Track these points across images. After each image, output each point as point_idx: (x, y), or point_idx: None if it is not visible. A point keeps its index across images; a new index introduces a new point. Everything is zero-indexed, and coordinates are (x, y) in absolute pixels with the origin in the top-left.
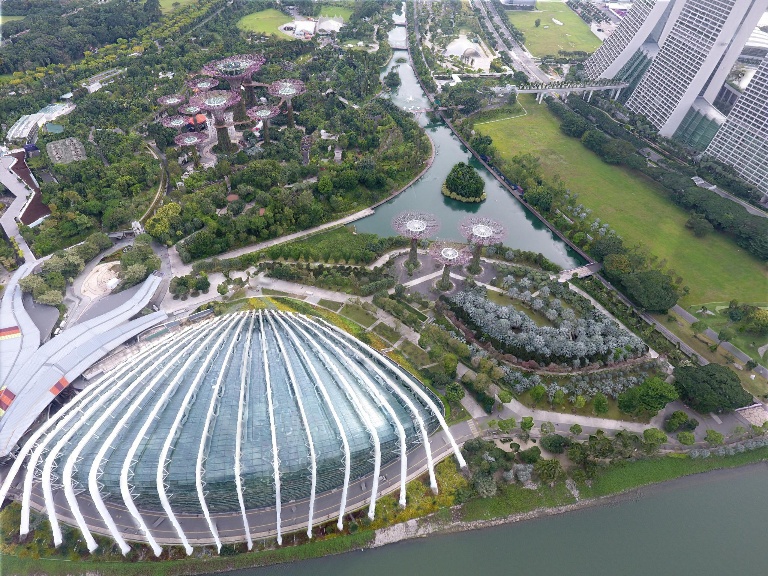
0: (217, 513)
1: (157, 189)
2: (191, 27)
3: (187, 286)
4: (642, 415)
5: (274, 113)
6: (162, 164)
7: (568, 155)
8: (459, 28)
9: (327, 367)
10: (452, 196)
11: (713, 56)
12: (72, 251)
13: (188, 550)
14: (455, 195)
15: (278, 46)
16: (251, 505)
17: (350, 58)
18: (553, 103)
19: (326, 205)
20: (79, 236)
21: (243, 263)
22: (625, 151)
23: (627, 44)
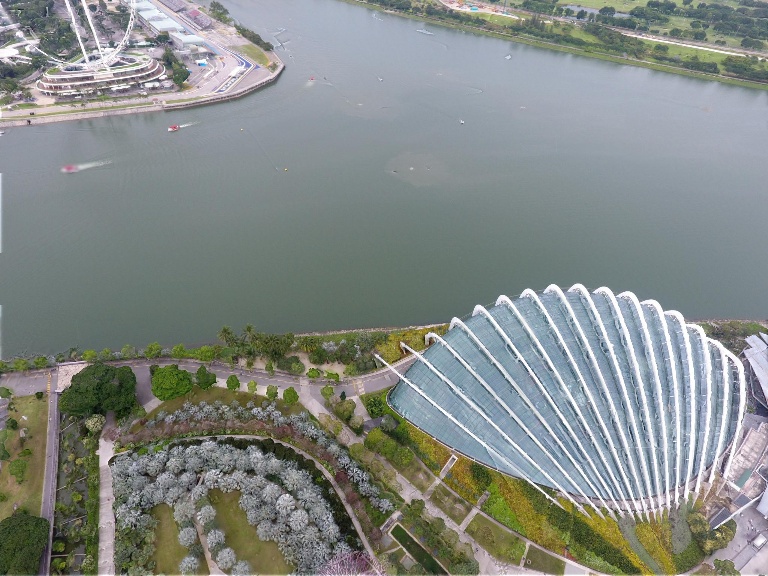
0: None
1: None
2: None
3: None
4: None
5: None
6: None
7: None
8: None
9: (517, 392)
10: None
11: None
12: None
13: None
14: None
15: None
16: None
17: None
18: None
19: None
20: None
21: None
22: None
23: None
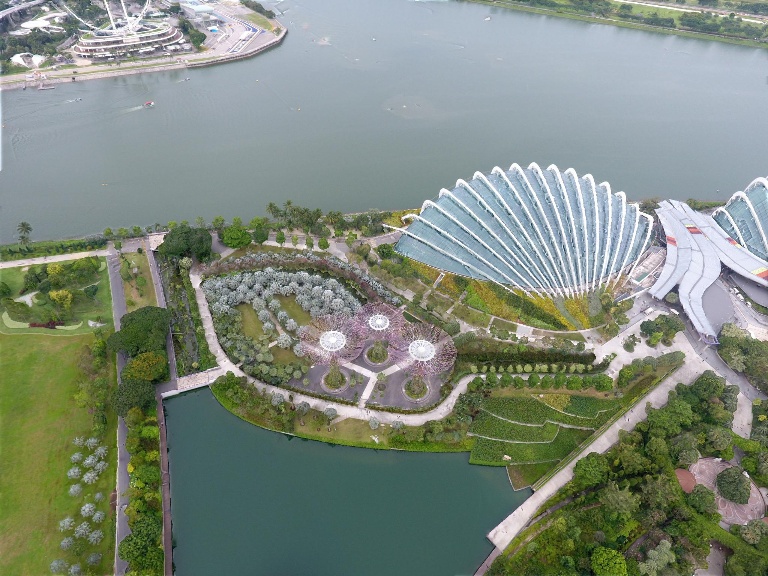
0: None
1: None
2: None
3: None
4: None
5: None
6: None
7: None
8: None
9: None
10: None
11: None
12: None
13: None
14: None
15: None
16: None
17: None
18: None
19: (585, 532)
20: None
21: None
22: None
23: None
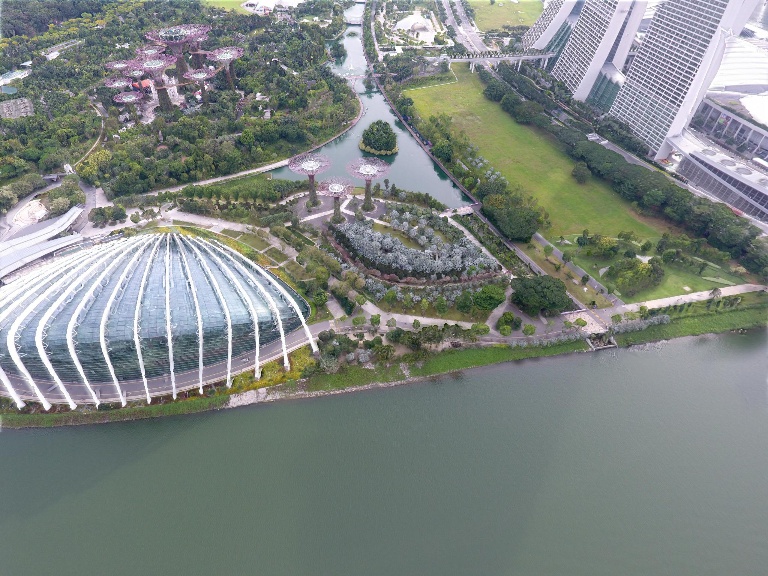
0: (102, 382)
1: (95, 141)
2: (156, 3)
3: (104, 215)
4: (477, 315)
5: (210, 75)
6: (104, 121)
7: (484, 116)
8: (415, 5)
9: (205, 271)
10: (366, 150)
11: (615, 23)
12: (7, 187)
13: (72, 405)
14: (369, 149)
15: (234, 20)
16: (128, 374)
17: (301, 31)
18: (482, 71)
19: (248, 156)
20: (18, 178)
21: (160, 200)
22: (534, 111)
23: (555, 16)
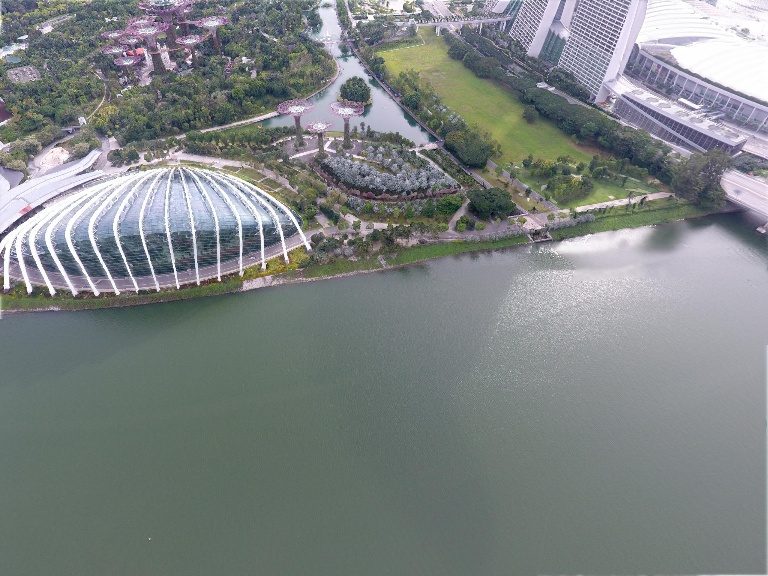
0: (138, 277)
1: (101, 100)
2: None
3: (121, 155)
4: (439, 219)
5: (199, 41)
6: (106, 84)
7: (449, 72)
8: None
9: (215, 190)
10: None
11: None
12: (31, 136)
13: (116, 291)
14: None
15: None
16: (159, 269)
17: (279, 3)
18: (446, 34)
19: (239, 109)
20: (37, 131)
21: None
22: (491, 66)
23: None
